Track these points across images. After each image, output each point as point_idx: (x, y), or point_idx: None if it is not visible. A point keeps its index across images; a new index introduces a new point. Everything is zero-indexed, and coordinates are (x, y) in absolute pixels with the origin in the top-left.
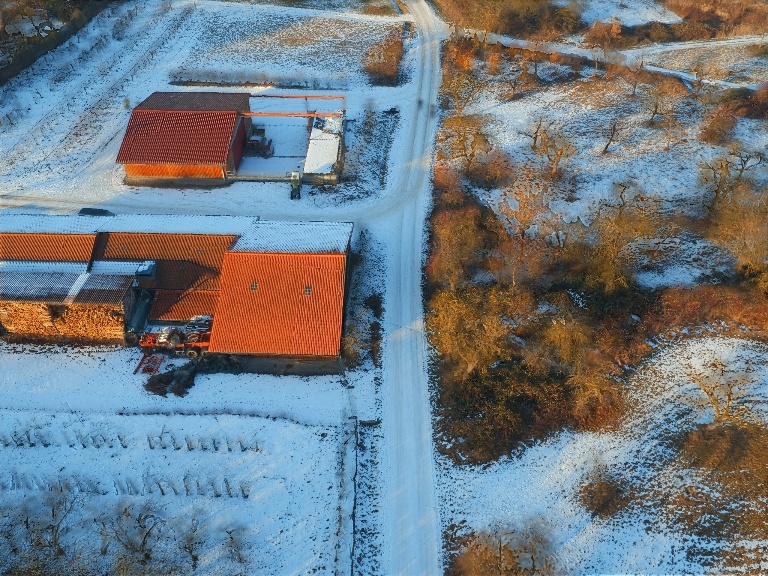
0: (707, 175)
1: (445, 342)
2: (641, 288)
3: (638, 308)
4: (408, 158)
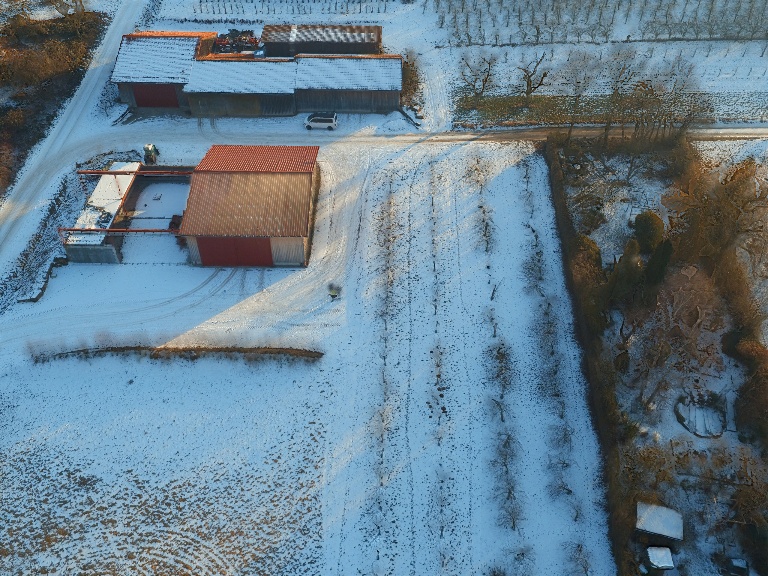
0: None
1: None
2: None
3: None
4: (19, 221)
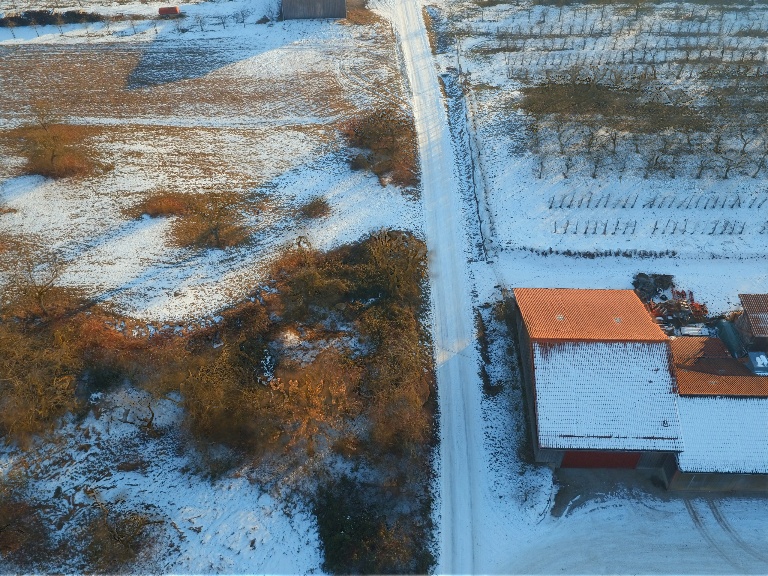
0: None
1: None
2: None
3: None
4: None
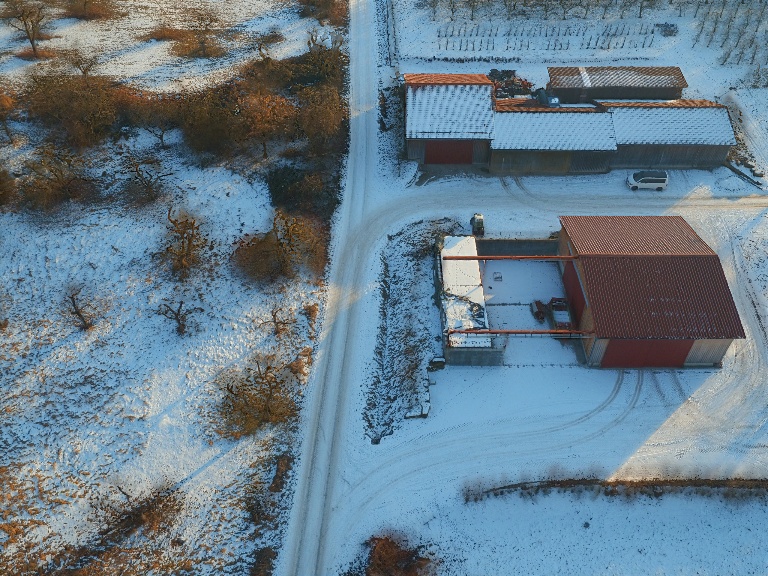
0: (4, 265)
1: None
2: None
3: None
4: (354, 310)
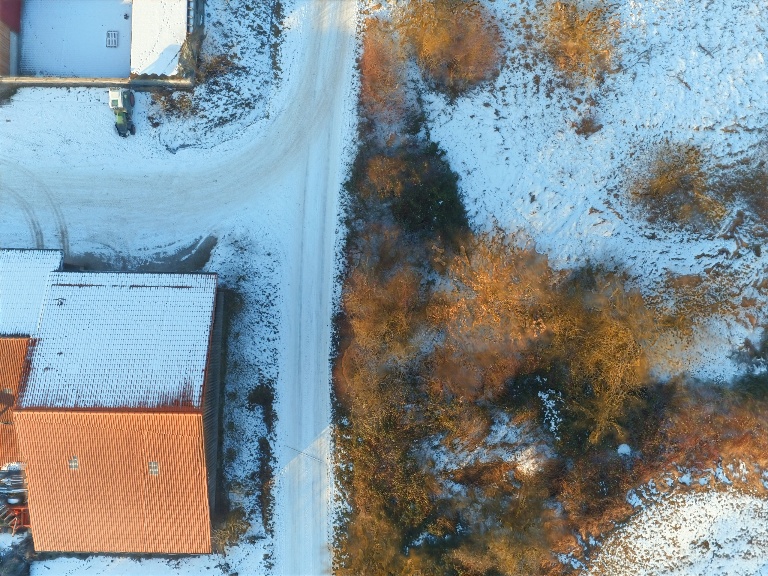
0: None
1: (357, 498)
2: (646, 391)
3: (632, 438)
4: None
